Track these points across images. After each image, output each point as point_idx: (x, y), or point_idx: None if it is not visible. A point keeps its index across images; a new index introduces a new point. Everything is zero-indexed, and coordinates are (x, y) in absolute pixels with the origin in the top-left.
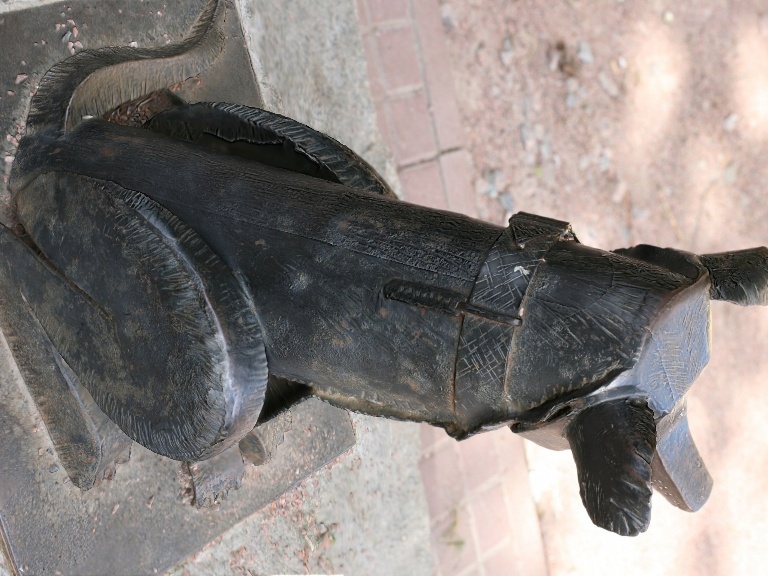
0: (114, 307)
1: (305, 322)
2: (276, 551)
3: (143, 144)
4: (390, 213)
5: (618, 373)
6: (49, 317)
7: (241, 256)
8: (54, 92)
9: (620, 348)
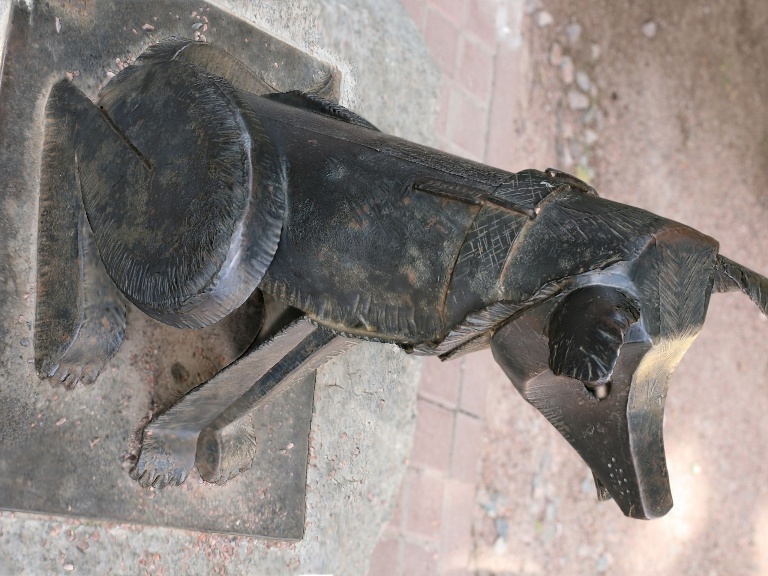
0: (159, 159)
1: (330, 205)
2: None
3: None
4: None
5: (616, 261)
6: (92, 175)
7: (291, 148)
8: (171, 44)
9: (623, 245)
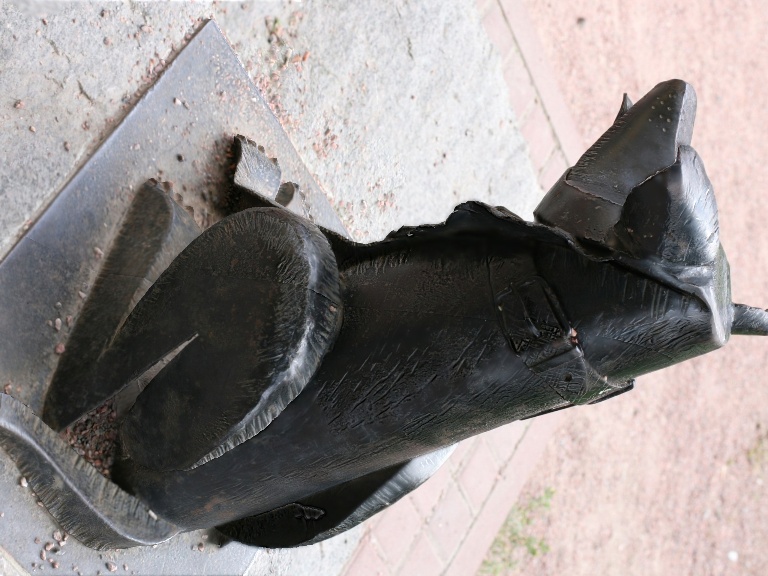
0: None
1: None
2: (306, 103)
3: (228, 500)
4: (457, 421)
5: None
6: None
7: None
8: None
9: None
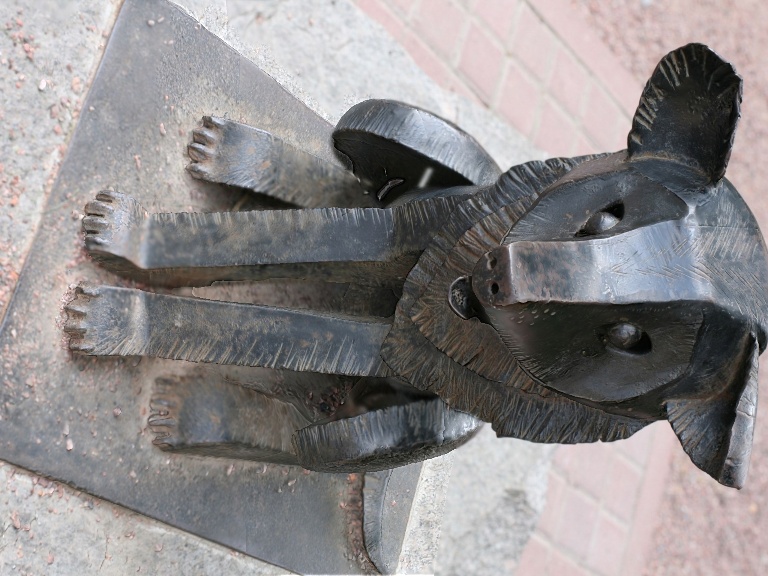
0: None
1: None
2: None
3: None
4: None
5: None
6: None
7: None
8: None
9: None
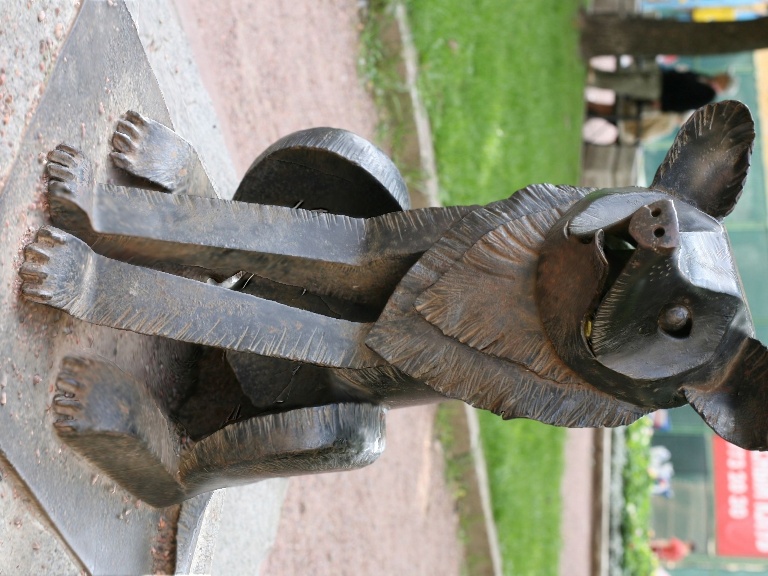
0: None
1: None
2: None
3: None
4: None
5: None
6: None
7: None
8: None
9: None
